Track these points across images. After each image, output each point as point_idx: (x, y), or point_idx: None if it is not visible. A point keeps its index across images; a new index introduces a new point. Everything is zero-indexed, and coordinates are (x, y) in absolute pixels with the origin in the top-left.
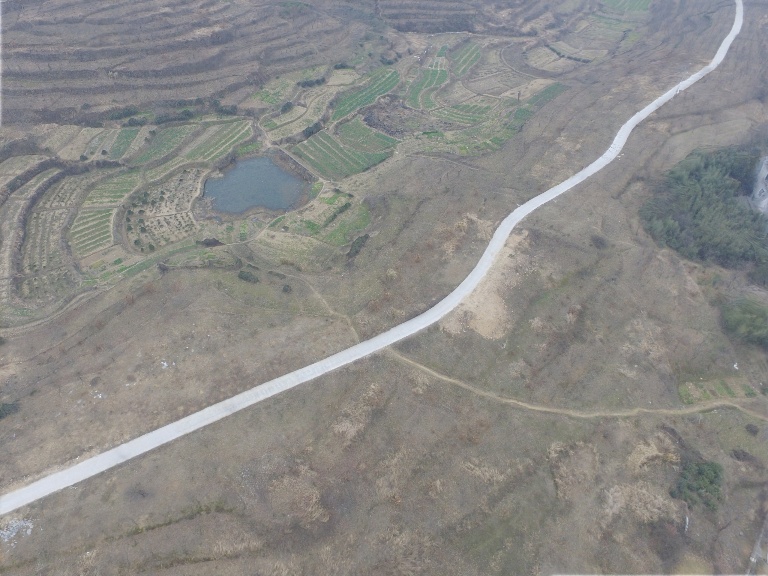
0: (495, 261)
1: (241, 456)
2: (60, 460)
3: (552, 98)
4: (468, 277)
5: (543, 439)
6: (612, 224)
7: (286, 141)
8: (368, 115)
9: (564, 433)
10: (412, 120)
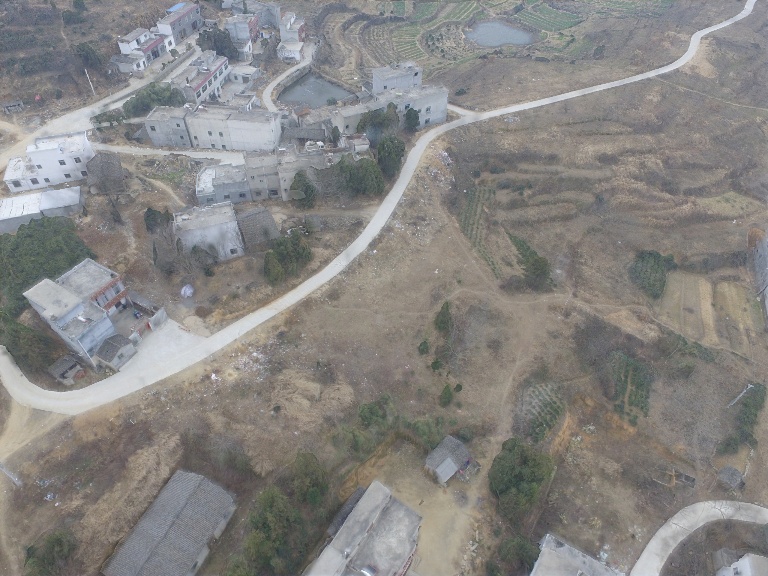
0: (698, 48)
1: (605, 103)
2: (512, 103)
3: None
4: (686, 53)
5: (751, 115)
6: (760, 41)
7: (504, 14)
8: (550, 3)
9: (761, 115)
10: (583, 7)
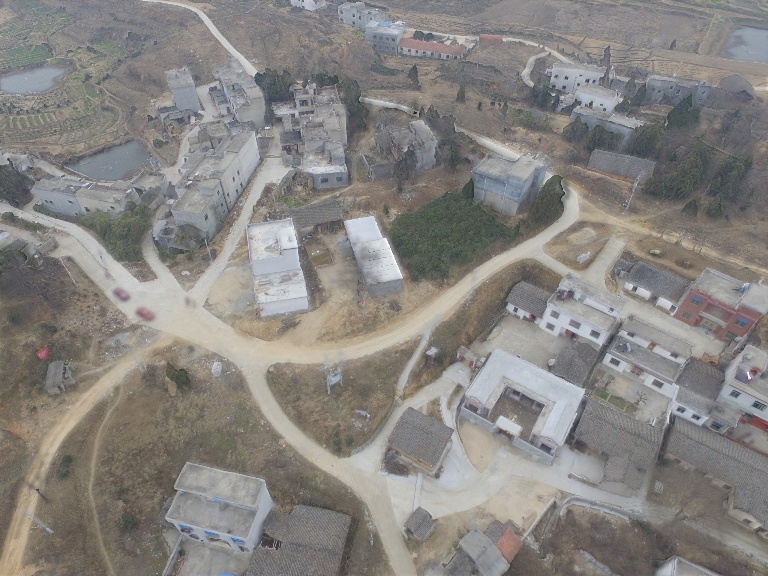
0: (177, 2)
1: None
2: None
3: (35, 2)
4: (182, 6)
5: None
6: None
7: None
8: None
9: None
10: (0, 43)
